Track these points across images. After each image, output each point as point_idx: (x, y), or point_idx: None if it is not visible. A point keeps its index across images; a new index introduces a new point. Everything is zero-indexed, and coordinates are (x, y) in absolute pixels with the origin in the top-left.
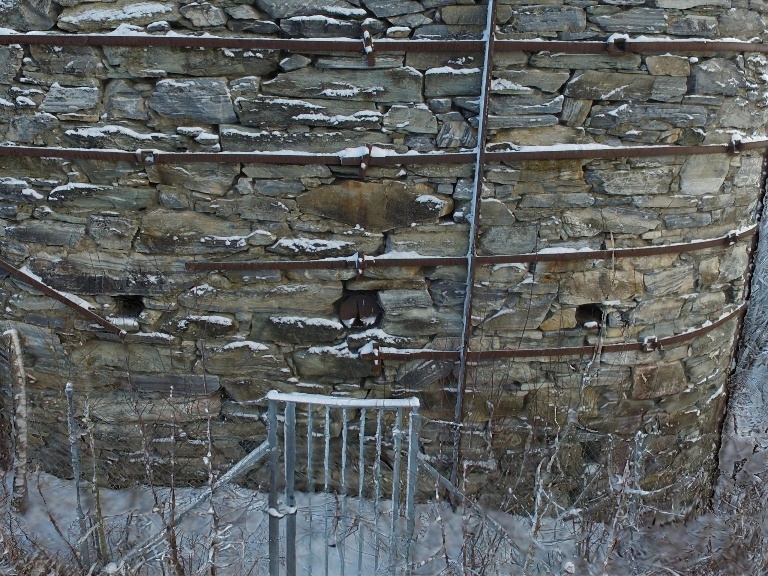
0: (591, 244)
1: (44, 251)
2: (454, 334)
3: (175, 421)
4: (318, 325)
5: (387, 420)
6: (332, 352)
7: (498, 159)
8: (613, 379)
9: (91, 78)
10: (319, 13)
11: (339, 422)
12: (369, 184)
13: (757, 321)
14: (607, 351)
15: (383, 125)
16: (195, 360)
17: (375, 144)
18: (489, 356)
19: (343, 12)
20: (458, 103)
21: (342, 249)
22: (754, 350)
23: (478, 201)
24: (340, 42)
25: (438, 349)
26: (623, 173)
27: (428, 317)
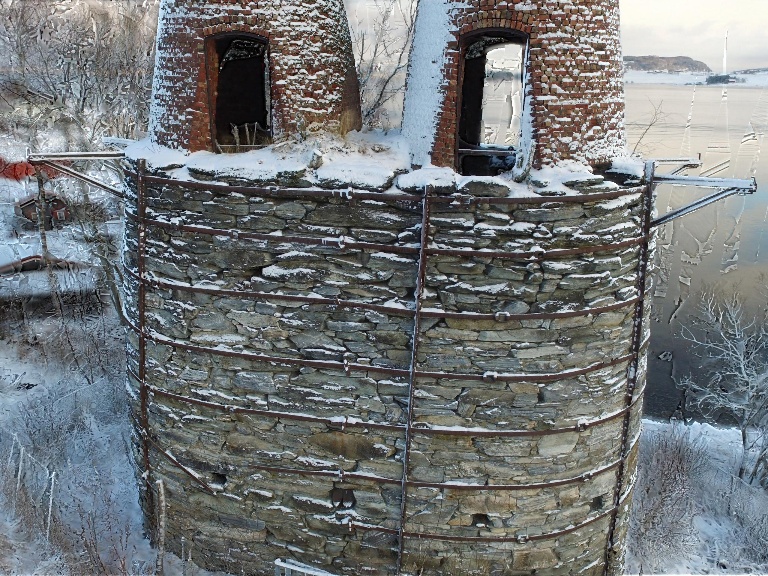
0: (479, 480)
1: (178, 444)
2: (397, 519)
3: (241, 540)
4: (319, 504)
5: (358, 560)
6: (326, 520)
7: (419, 431)
8: (498, 557)
9: (205, 367)
10: (321, 347)
11: (331, 556)
12: (347, 435)
13: None
14: (492, 541)
15: (355, 406)
16: (252, 511)
17: (351, 415)
18: (416, 535)
19: (334, 348)
20: (397, 399)
21: (332, 467)
22: None
23: (408, 452)
24: (331, 364)
25: (387, 527)
26: (497, 445)
27: (381, 508)
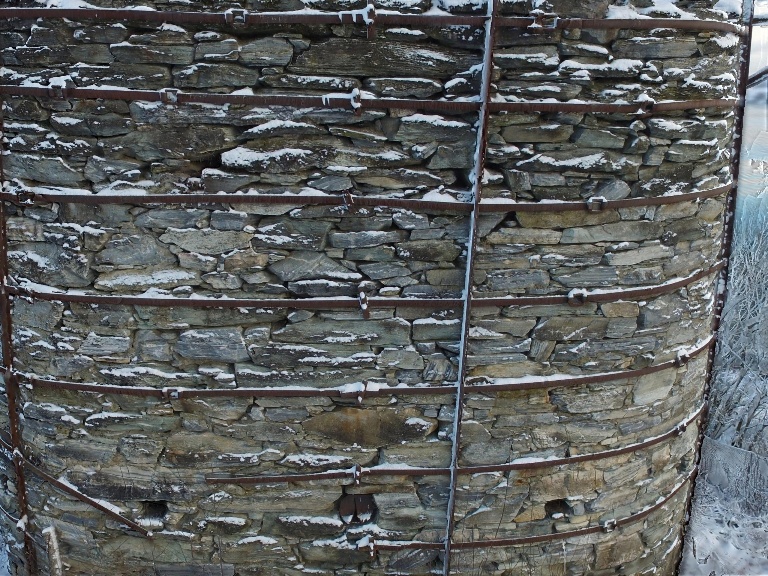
0: (557, 452)
1: (80, 464)
2: (439, 527)
3: None
4: (321, 523)
5: None
6: (333, 545)
7: (476, 391)
8: (578, 556)
9: (124, 329)
10: (321, 277)
11: None
12: (365, 411)
13: (728, 382)
14: (572, 536)
15: (377, 364)
16: (213, 552)
17: (370, 379)
18: (470, 546)
19: (342, 276)
20: (441, 346)
21: (342, 463)
22: (724, 416)
23: (459, 424)
24: (340, 301)
25: (426, 541)
26: (583, 396)
27: (417, 514)
